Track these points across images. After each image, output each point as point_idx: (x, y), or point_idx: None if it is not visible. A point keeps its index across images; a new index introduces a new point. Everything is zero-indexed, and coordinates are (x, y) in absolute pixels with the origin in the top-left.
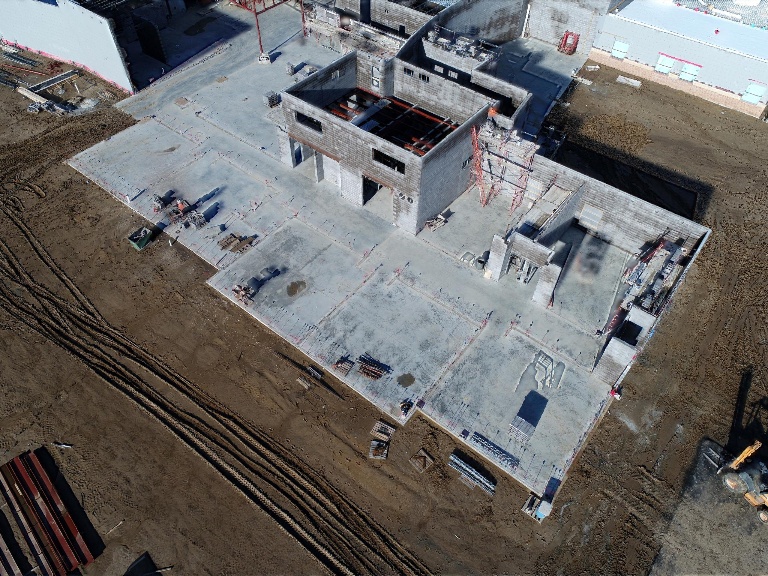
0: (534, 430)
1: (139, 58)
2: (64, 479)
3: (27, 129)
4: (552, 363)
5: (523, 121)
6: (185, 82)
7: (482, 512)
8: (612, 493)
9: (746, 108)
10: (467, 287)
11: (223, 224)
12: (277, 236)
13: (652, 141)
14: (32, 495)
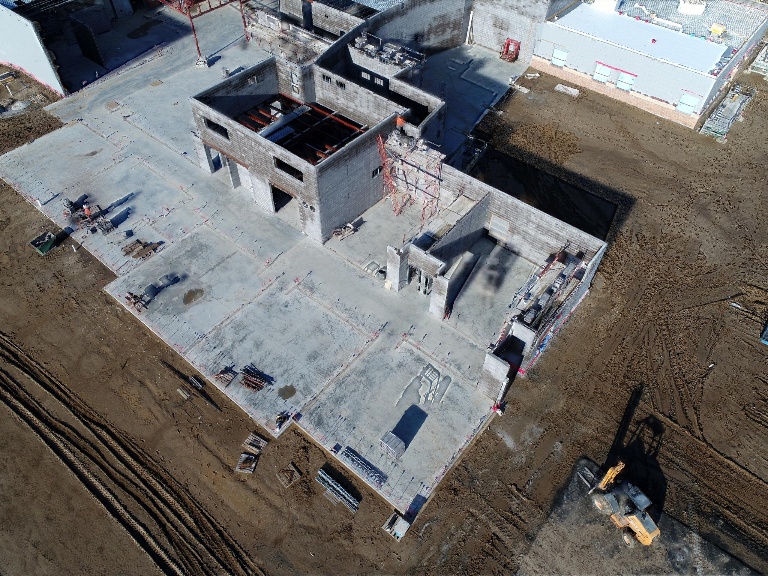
0: (407, 446)
1: (77, 61)
2: None
3: None
4: (438, 377)
5: (437, 130)
6: (119, 85)
7: (341, 529)
8: (478, 512)
9: (681, 118)
10: (366, 297)
11: (131, 230)
12: (183, 243)
13: (581, 151)
14: None
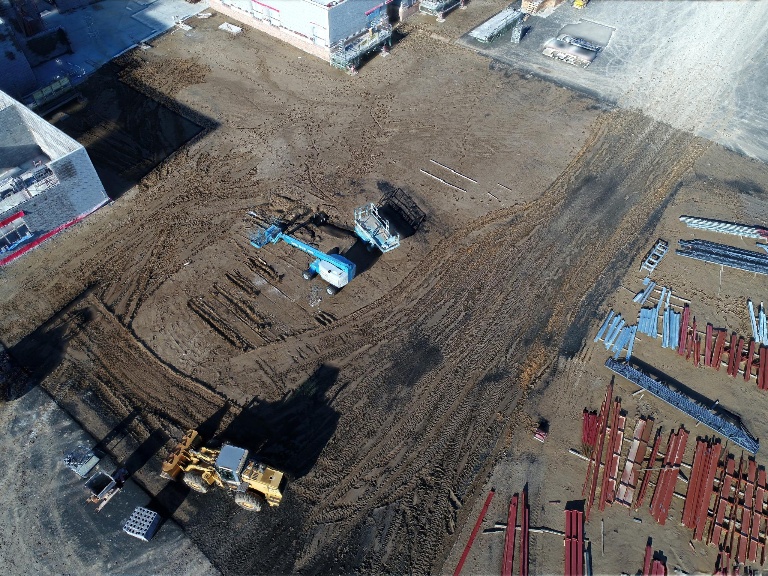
0: None
1: None
2: None
3: None
4: None
5: (5, 51)
6: None
7: None
8: None
9: (320, 53)
10: None
11: None
12: None
13: (205, 81)
14: None
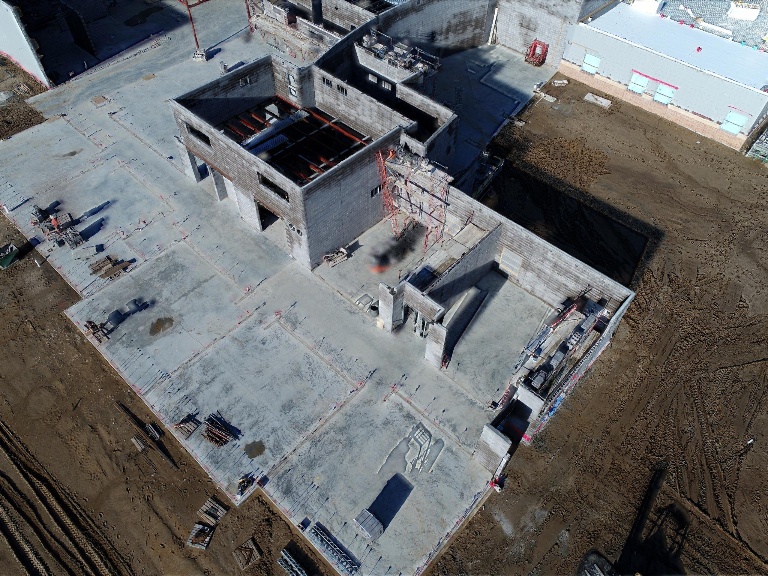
0: (387, 525)
1: (68, 49)
2: None
3: None
4: (430, 440)
5: (447, 146)
6: (109, 78)
7: None
8: None
9: (725, 138)
10: (354, 337)
11: (102, 244)
12: (157, 262)
13: (610, 172)
14: None
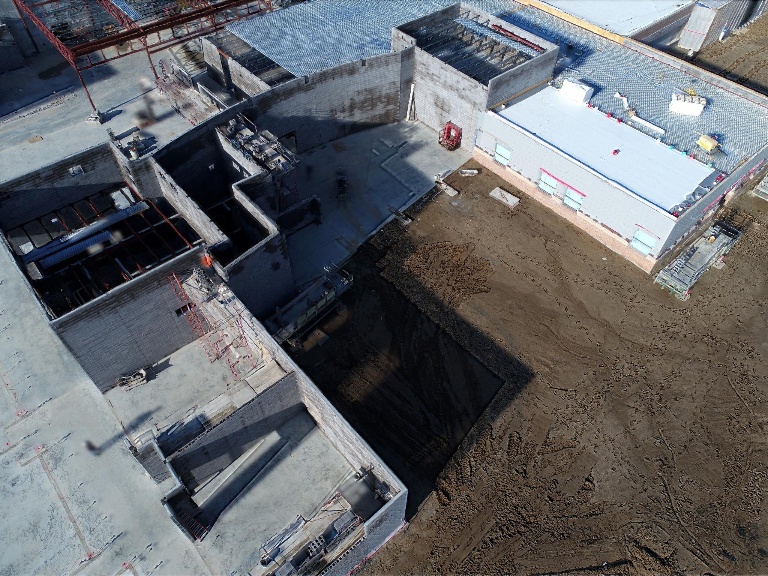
0: None
1: None
2: None
3: None
4: None
5: (272, 263)
6: None
7: None
8: None
9: (635, 258)
10: (115, 487)
11: None
12: None
13: (488, 290)
14: None
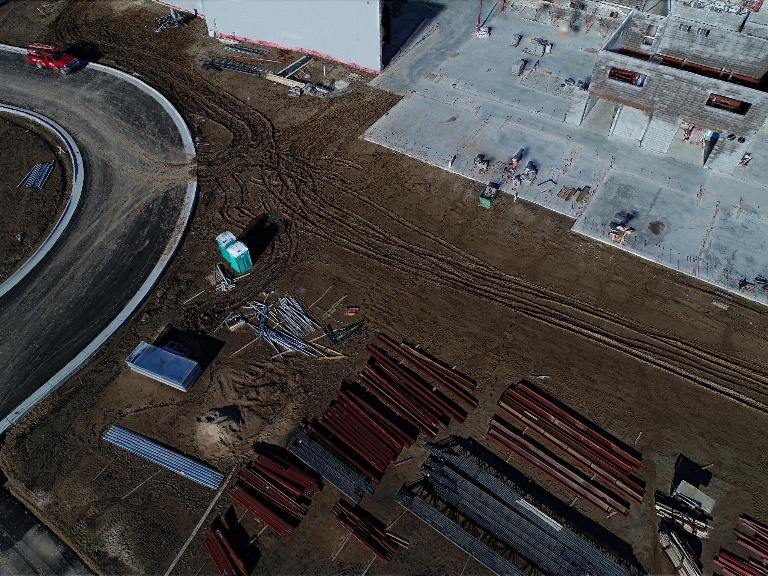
0: None
1: None
2: (562, 404)
3: (299, 111)
4: None
5: None
6: (421, 59)
7: None
8: None
9: None
10: None
11: (550, 179)
12: (607, 185)
13: None
14: (547, 419)
